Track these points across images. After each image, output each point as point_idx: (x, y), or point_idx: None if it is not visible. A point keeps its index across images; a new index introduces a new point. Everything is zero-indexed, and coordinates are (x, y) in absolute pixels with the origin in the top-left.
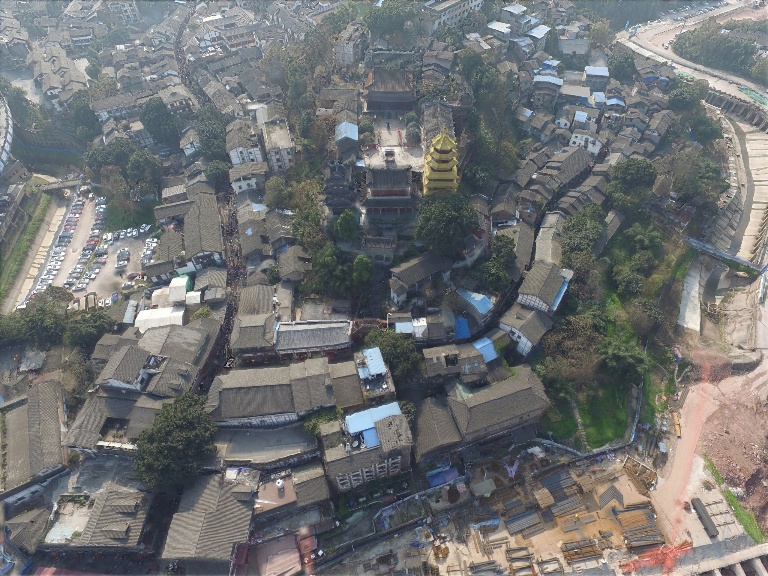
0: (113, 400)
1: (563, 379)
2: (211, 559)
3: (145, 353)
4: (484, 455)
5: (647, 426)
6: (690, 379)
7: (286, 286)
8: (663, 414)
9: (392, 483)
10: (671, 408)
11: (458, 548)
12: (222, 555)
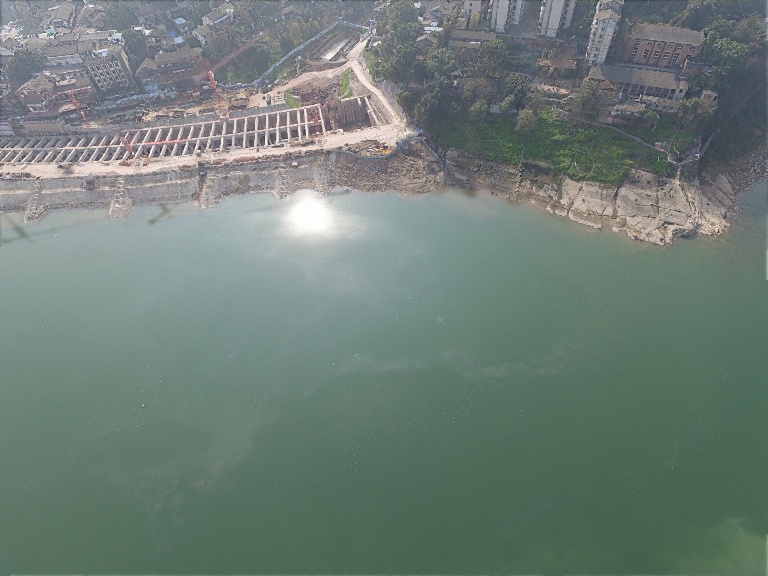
0: (1, 58)
1: (213, 49)
2: (34, 95)
3: (17, 41)
4: (179, 88)
5: (266, 80)
6: (306, 71)
7: (95, 28)
8: (281, 80)
9: (127, 90)
10: (288, 79)
11: (154, 113)
12: (37, 90)
